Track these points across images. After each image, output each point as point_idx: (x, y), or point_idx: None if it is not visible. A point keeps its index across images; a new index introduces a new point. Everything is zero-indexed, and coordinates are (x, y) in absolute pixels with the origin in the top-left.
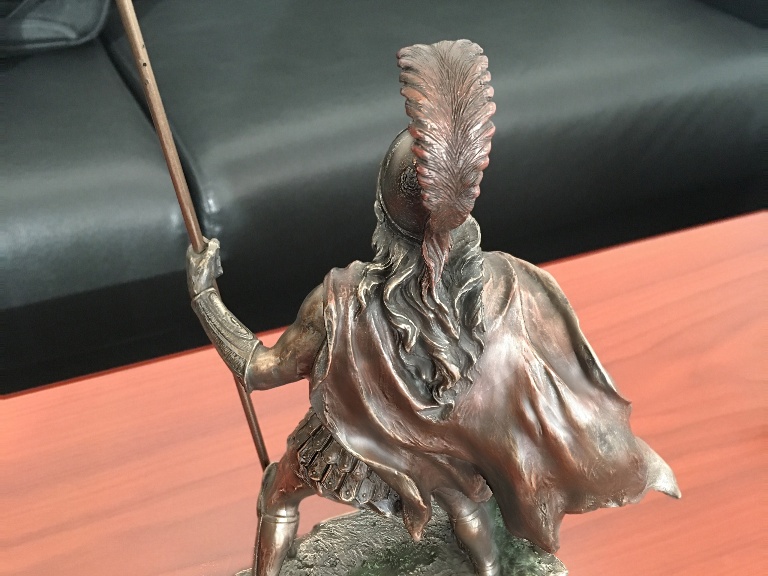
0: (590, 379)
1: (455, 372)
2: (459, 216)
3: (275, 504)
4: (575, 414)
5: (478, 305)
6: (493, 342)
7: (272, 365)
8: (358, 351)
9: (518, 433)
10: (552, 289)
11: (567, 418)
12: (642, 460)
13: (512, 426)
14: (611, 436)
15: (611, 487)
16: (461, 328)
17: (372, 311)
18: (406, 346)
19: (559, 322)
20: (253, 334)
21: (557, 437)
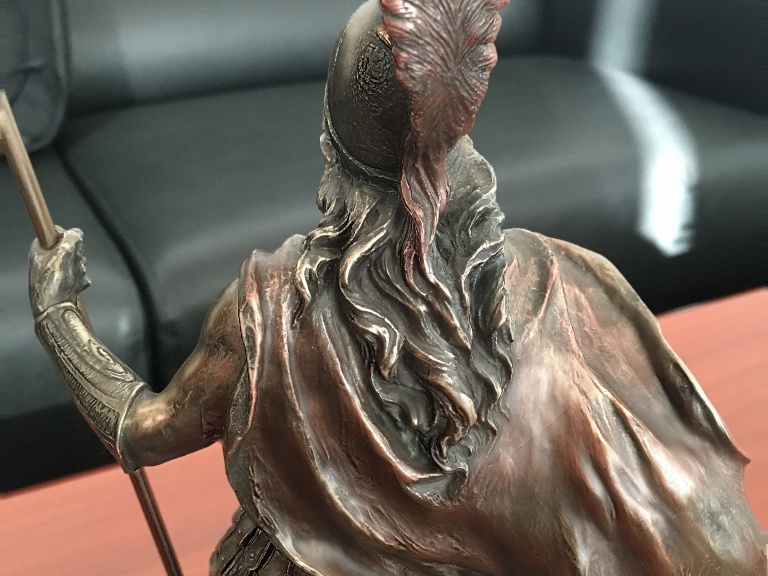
0: (687, 420)
1: (468, 407)
2: (462, 108)
3: None
4: (668, 479)
5: (500, 291)
6: (526, 362)
7: (162, 418)
8: (302, 382)
9: (575, 518)
10: (611, 280)
11: (655, 487)
12: None
13: (565, 506)
14: (727, 516)
15: None
16: (473, 336)
17: (322, 309)
18: (382, 365)
19: (627, 331)
20: (135, 374)
21: (641, 521)
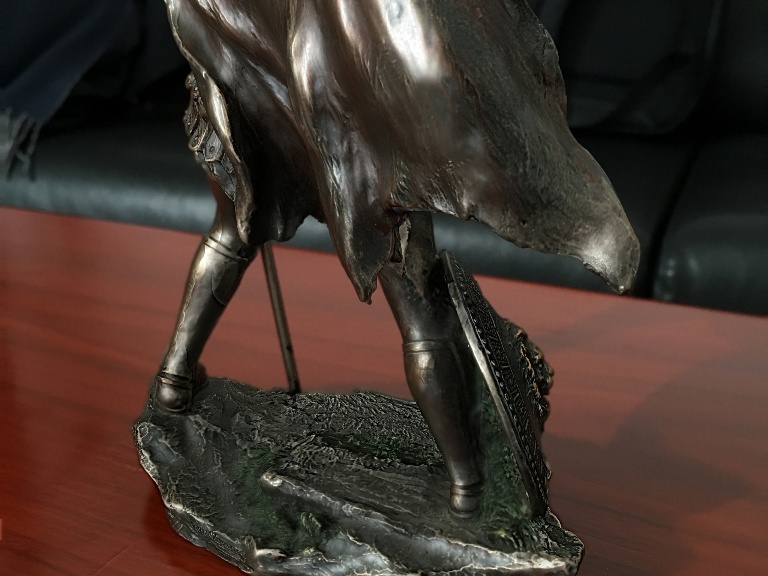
0: None
1: None
2: None
3: None
4: None
5: None
6: None
7: None
8: None
9: None
10: None
11: None
12: (504, 114)
13: None
14: None
15: (422, 137)
16: None
17: None
18: None
19: None
20: None
21: None
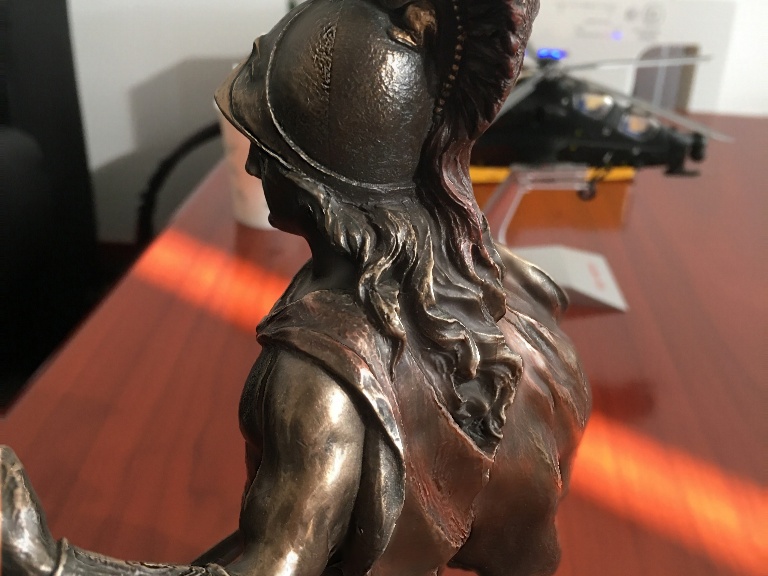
0: (549, 307)
1: None
2: None
3: None
4: (567, 356)
5: None
6: None
7: (287, 575)
8: (405, 432)
9: (537, 425)
10: None
11: (563, 367)
12: None
13: (530, 421)
14: None
15: None
16: None
17: (405, 345)
18: (472, 366)
19: None
20: None
21: (567, 398)
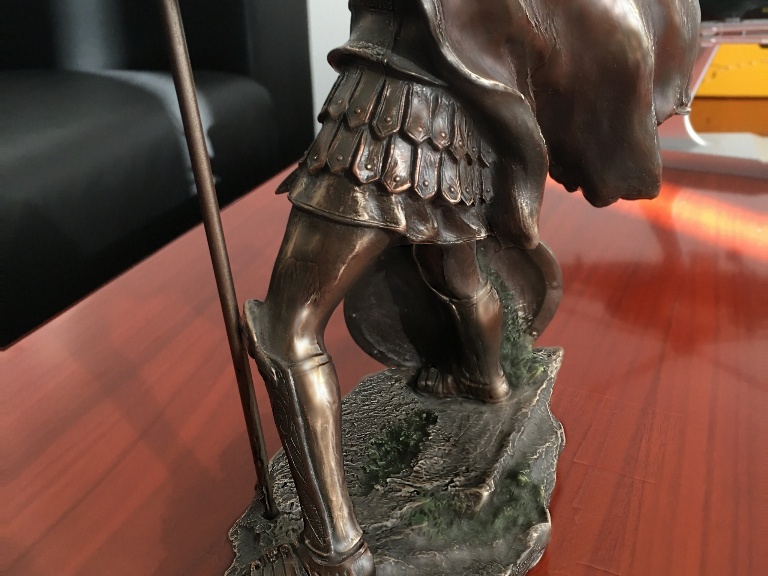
0: None
1: None
2: None
3: (301, 339)
4: None
5: None
6: None
7: None
8: None
9: None
10: None
11: None
12: None
13: None
14: None
15: (692, 58)
16: None
17: None
18: None
19: None
20: None
21: None
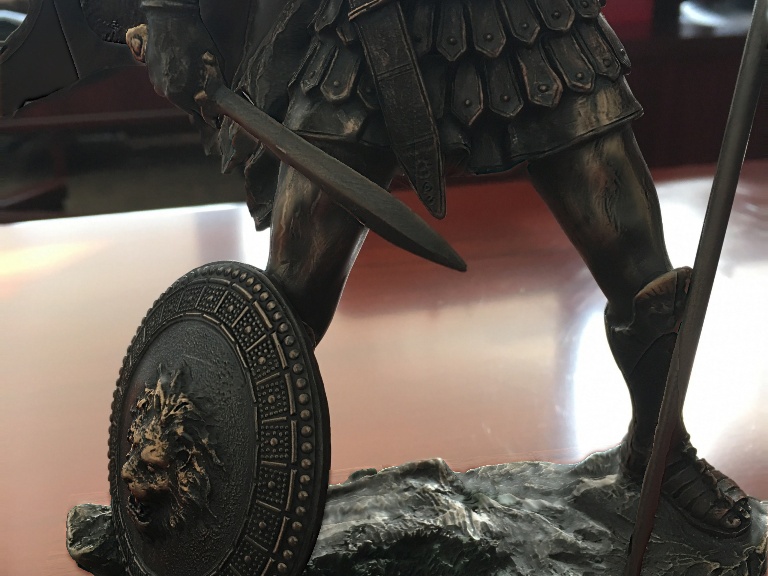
0: None
1: None
2: None
3: None
4: None
5: None
6: None
7: None
8: None
9: None
10: None
11: None
12: None
13: None
14: None
15: (136, 4)
16: None
17: None
18: None
19: None
20: None
21: None
